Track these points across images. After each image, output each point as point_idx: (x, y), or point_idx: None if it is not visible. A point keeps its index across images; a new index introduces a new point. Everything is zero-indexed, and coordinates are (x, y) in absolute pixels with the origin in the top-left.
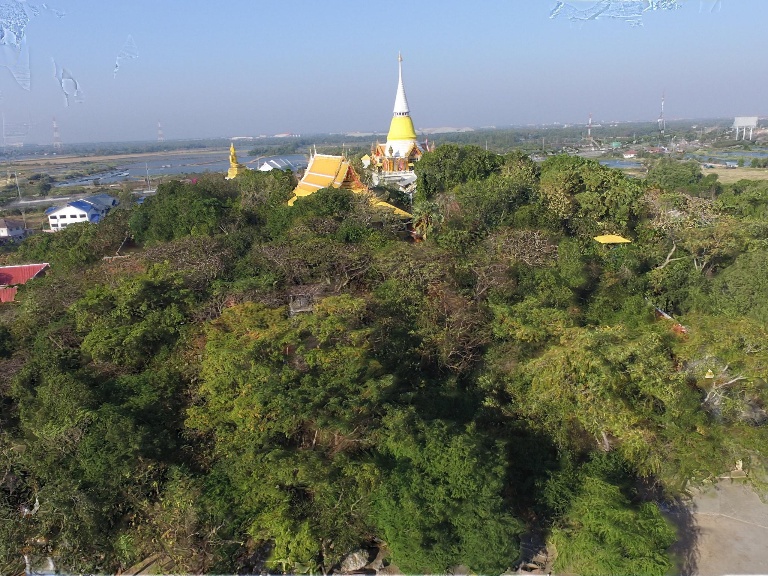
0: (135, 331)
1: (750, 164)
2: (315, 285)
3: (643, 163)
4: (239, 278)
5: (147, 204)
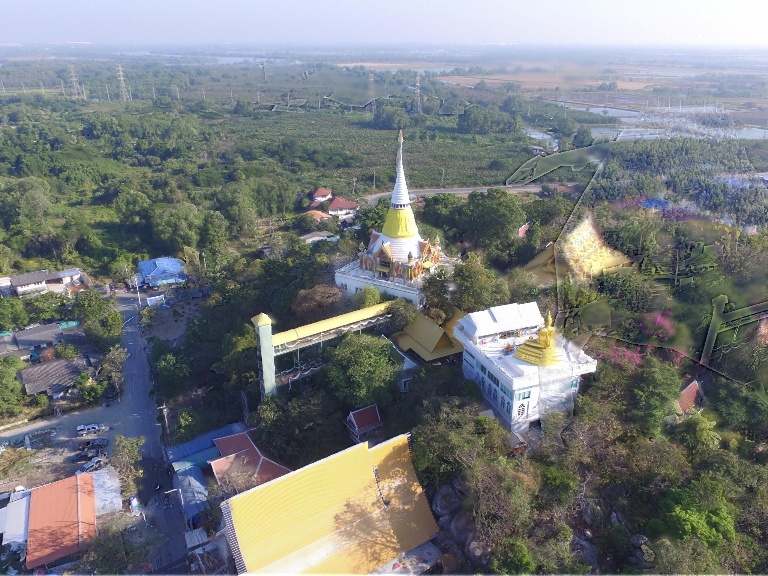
0: None
1: None
2: None
3: None
4: None
5: None
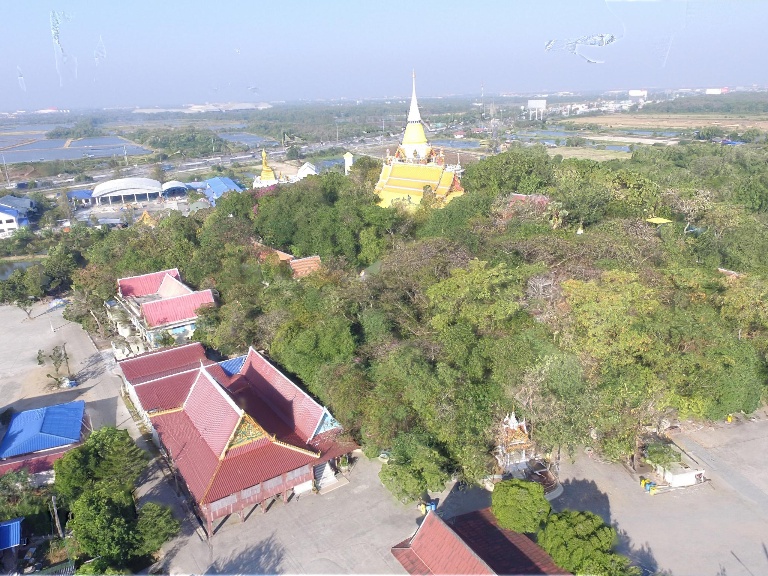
0: (511, 306)
1: (564, 143)
2: (568, 266)
3: (489, 145)
4: (492, 266)
5: (280, 212)
